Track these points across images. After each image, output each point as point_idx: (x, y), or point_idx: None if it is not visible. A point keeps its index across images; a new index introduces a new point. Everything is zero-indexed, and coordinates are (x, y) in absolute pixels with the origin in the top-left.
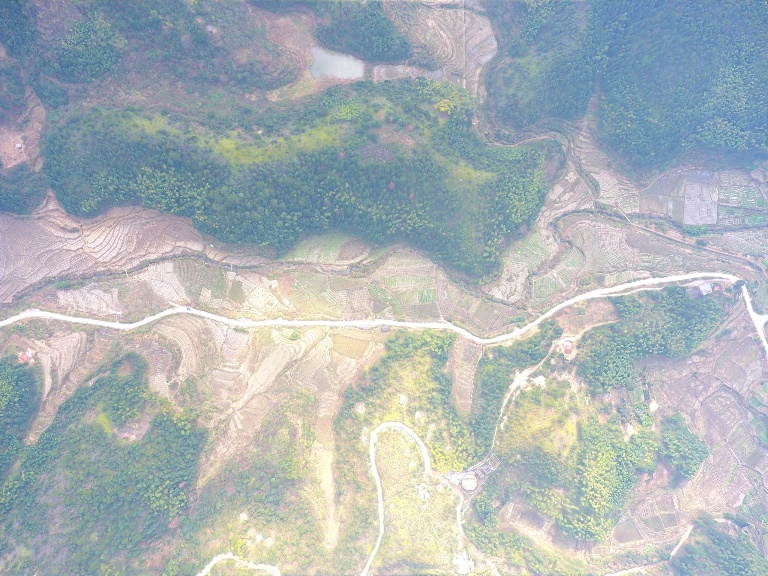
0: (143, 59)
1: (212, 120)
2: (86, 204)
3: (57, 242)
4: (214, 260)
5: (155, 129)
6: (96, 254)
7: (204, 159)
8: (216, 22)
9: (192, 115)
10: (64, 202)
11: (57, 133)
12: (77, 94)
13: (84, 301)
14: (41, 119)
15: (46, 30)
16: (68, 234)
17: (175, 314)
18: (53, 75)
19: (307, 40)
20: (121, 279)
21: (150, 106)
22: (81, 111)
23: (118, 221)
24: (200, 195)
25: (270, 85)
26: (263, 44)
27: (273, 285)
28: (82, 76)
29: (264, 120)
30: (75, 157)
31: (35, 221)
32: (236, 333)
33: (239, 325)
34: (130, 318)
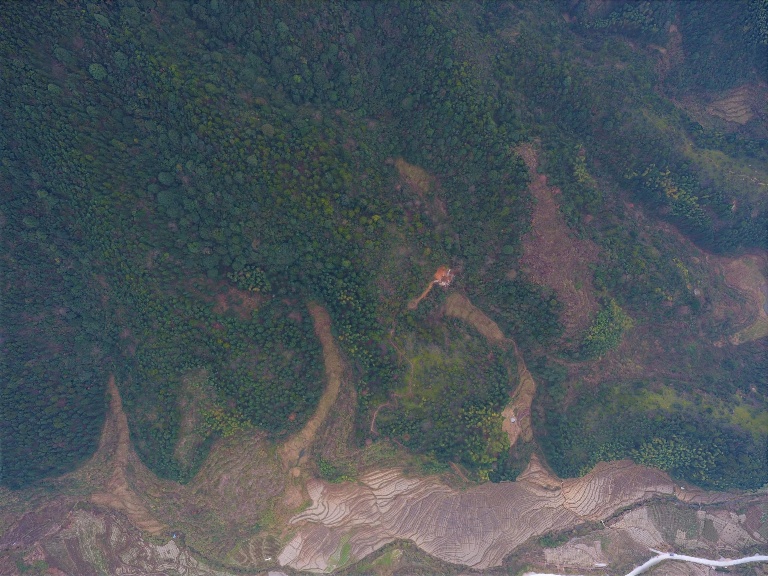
0: (631, 327)
1: (712, 385)
2: (583, 471)
3: (539, 501)
4: (684, 501)
5: (668, 404)
6: (576, 509)
7: (719, 429)
8: (700, 285)
9: (689, 380)
10: (559, 470)
11: (574, 416)
12: (580, 371)
13: (570, 557)
14: (531, 391)
15: (571, 324)
16: (549, 493)
17: (662, 563)
18: (563, 359)
19: (758, 279)
20: (601, 530)
21: (650, 376)
22: (586, 388)
23: (594, 474)
24: (706, 459)
25: (735, 331)
26: (729, 293)
27: (742, 520)
28: (593, 358)
29: (749, 374)
30: (588, 435)
31: (516, 483)
32: (718, 574)
33: (719, 565)
34: (619, 571)
